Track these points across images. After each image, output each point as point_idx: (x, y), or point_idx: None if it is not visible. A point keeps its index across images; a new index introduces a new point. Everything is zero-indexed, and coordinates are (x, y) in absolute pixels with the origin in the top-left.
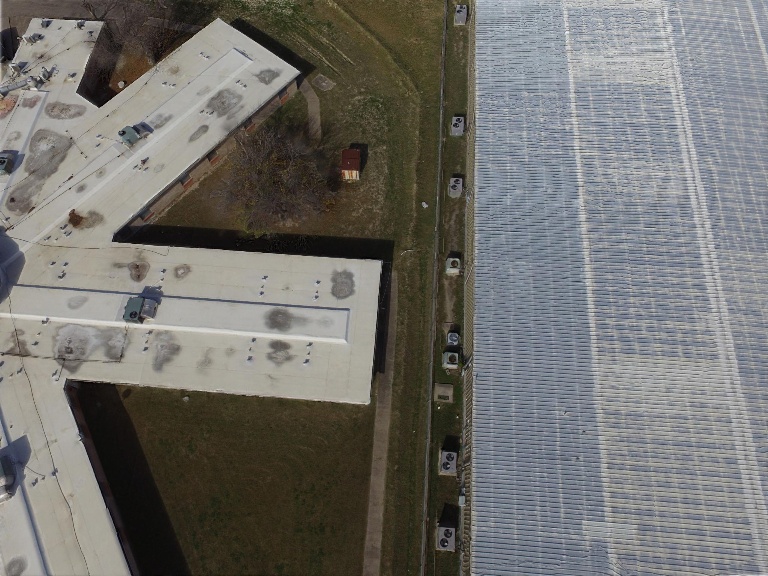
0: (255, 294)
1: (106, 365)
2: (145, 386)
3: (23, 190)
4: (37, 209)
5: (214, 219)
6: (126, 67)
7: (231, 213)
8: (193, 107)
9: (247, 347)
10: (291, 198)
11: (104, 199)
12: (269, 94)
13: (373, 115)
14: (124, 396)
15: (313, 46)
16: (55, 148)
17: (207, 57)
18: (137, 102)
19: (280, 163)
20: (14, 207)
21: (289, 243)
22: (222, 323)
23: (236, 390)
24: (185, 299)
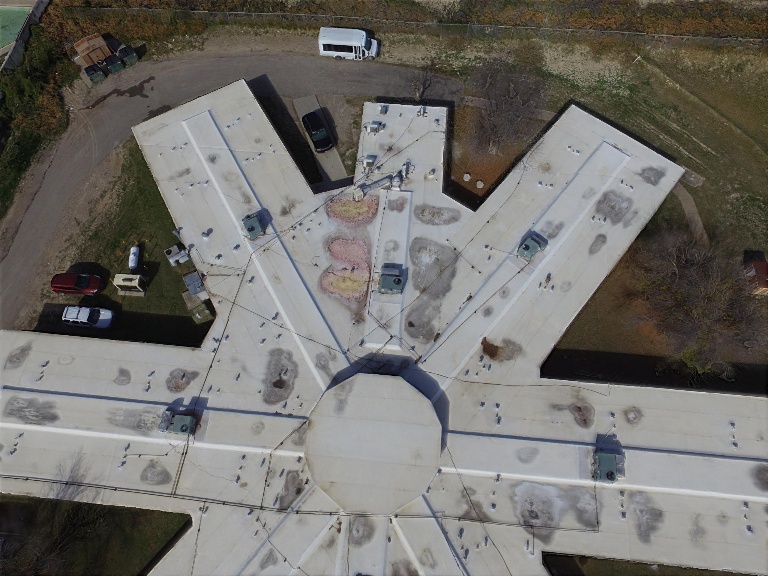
0: (728, 446)
1: (584, 535)
2: (636, 562)
3: (420, 312)
4: (445, 337)
5: (619, 342)
6: (464, 156)
7: (637, 334)
8: (583, 213)
9: (741, 514)
10: (738, 328)
11: (515, 324)
12: (661, 197)
13: (758, 217)
14: (581, 562)
15: (665, 133)
16: (440, 261)
17: (578, 152)
18: (515, 205)
19: (719, 287)
20: (416, 333)
21: (715, 373)
22: (705, 484)
23: (746, 569)
24: (652, 452)
